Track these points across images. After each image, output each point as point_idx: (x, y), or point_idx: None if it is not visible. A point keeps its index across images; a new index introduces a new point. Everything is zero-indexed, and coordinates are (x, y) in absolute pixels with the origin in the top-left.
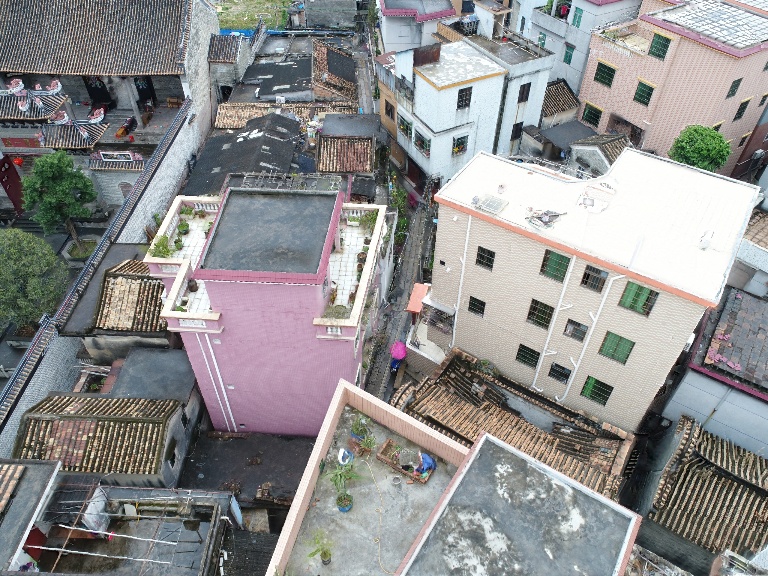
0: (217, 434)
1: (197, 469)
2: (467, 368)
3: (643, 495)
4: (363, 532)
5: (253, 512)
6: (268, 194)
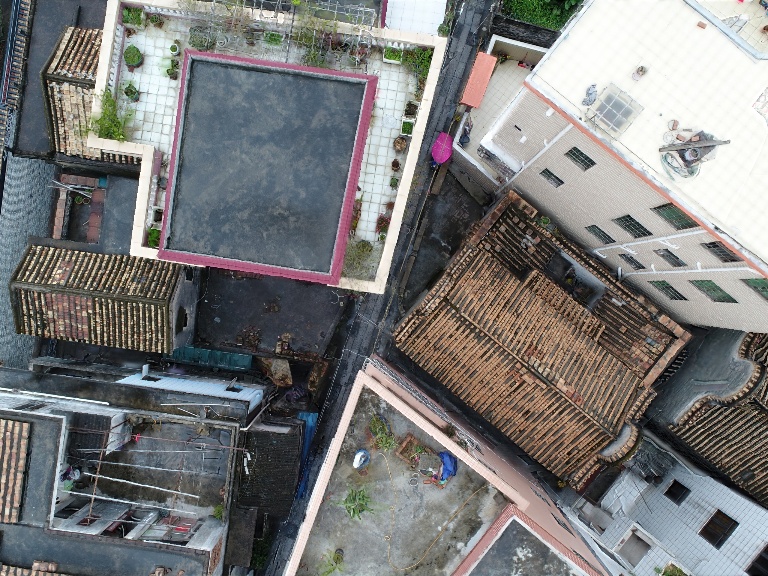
0: (229, 274)
1: (213, 312)
2: (522, 216)
3: (673, 399)
4: (375, 529)
5: (274, 358)
6: (253, 70)
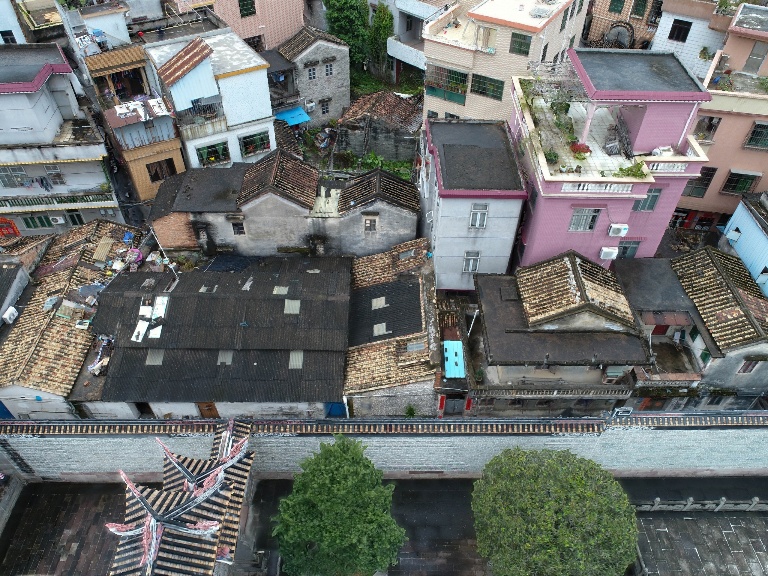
0: None
1: None
2: None
3: None
4: None
5: None
6: None
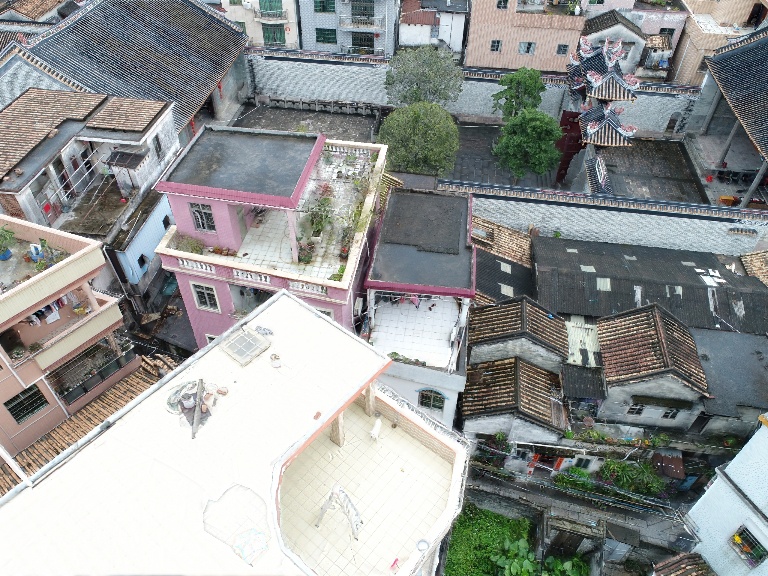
0: None
1: None
2: None
3: None
4: None
5: None
6: None
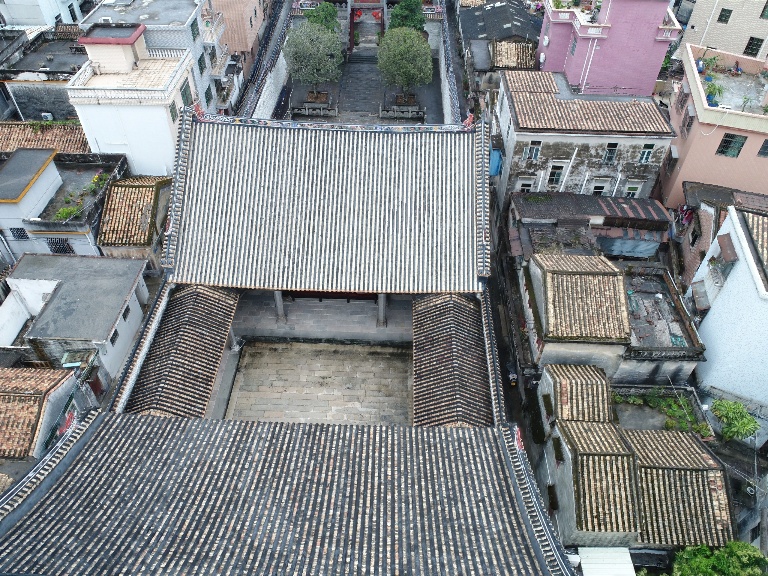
0: None
1: None
2: None
3: None
4: None
5: None
6: None
